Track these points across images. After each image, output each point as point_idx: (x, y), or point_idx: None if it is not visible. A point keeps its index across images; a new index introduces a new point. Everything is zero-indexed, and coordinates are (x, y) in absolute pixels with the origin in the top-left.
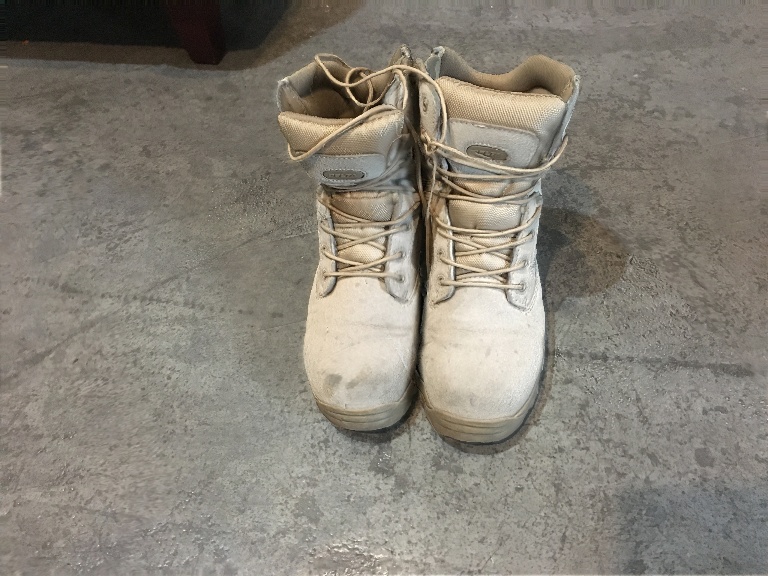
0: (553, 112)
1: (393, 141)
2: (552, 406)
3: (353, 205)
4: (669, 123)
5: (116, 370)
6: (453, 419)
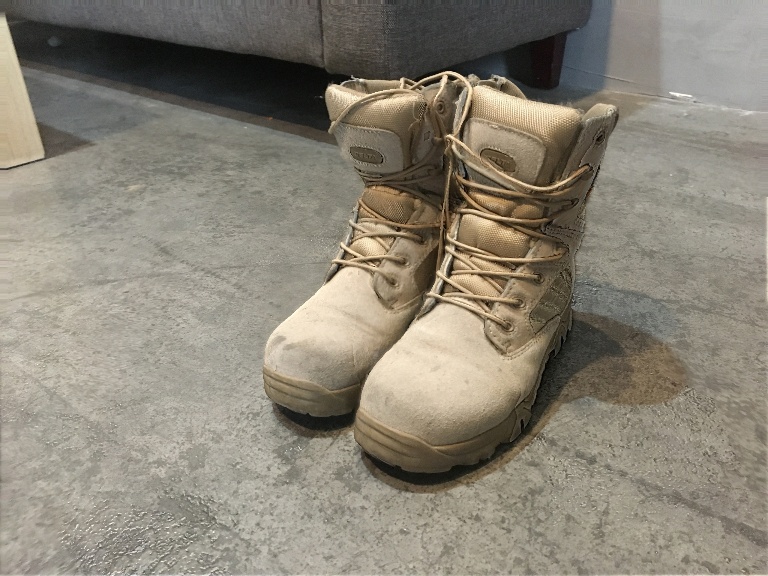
0: (565, 121)
1: (411, 125)
2: (498, 477)
3: (374, 196)
4: None
5: (147, 307)
6: (365, 417)
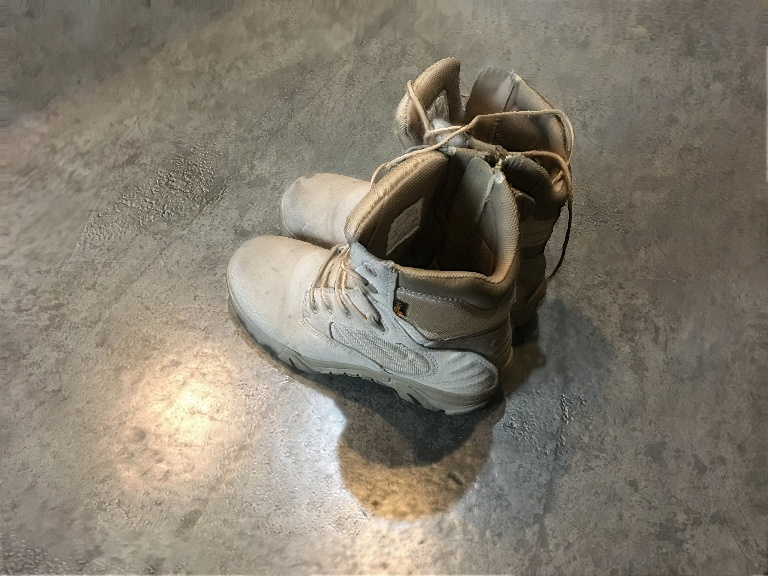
0: None
1: None
2: (244, 350)
3: None
4: None
5: None
6: None
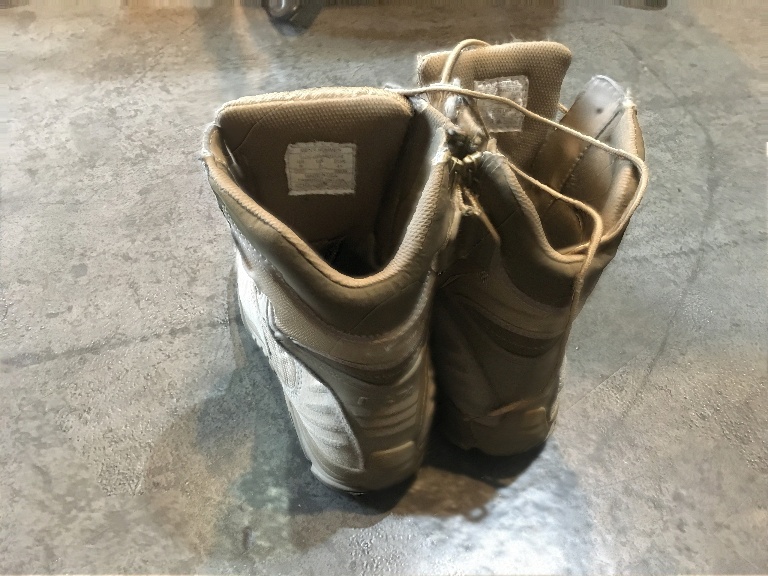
0: None
1: None
2: (224, 272)
3: None
4: None
5: None
6: None
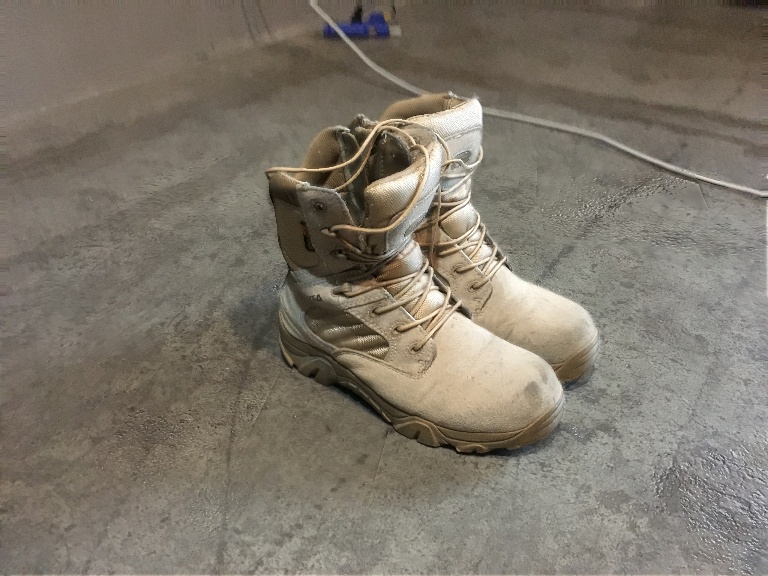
0: None
1: None
2: None
3: (411, 261)
4: None
5: None
6: (587, 348)
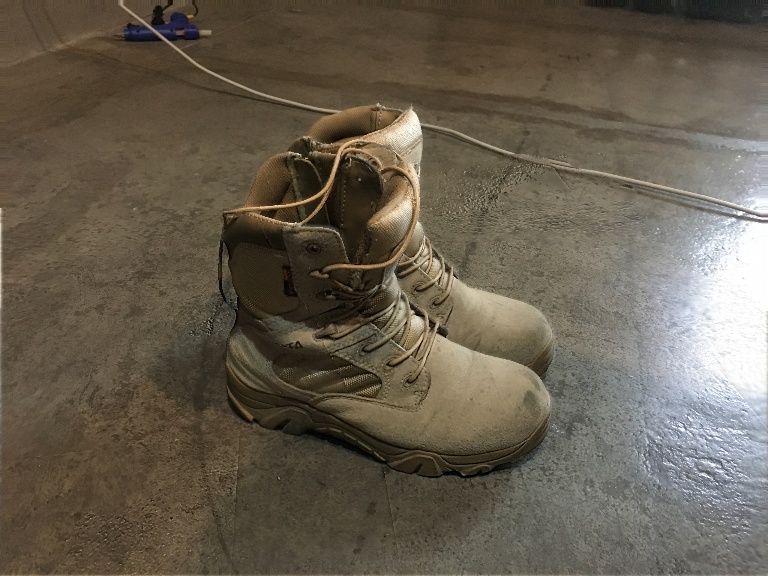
0: None
1: None
2: None
3: (393, 289)
4: (214, 210)
5: None
6: (550, 345)
